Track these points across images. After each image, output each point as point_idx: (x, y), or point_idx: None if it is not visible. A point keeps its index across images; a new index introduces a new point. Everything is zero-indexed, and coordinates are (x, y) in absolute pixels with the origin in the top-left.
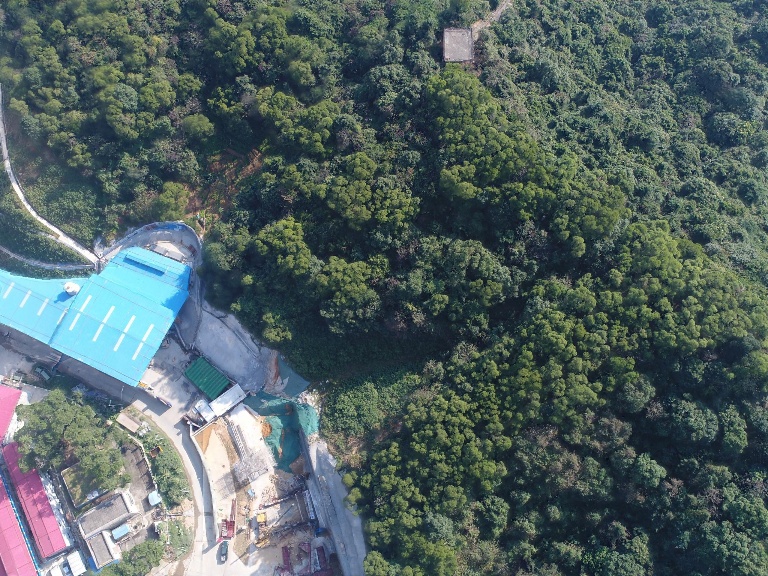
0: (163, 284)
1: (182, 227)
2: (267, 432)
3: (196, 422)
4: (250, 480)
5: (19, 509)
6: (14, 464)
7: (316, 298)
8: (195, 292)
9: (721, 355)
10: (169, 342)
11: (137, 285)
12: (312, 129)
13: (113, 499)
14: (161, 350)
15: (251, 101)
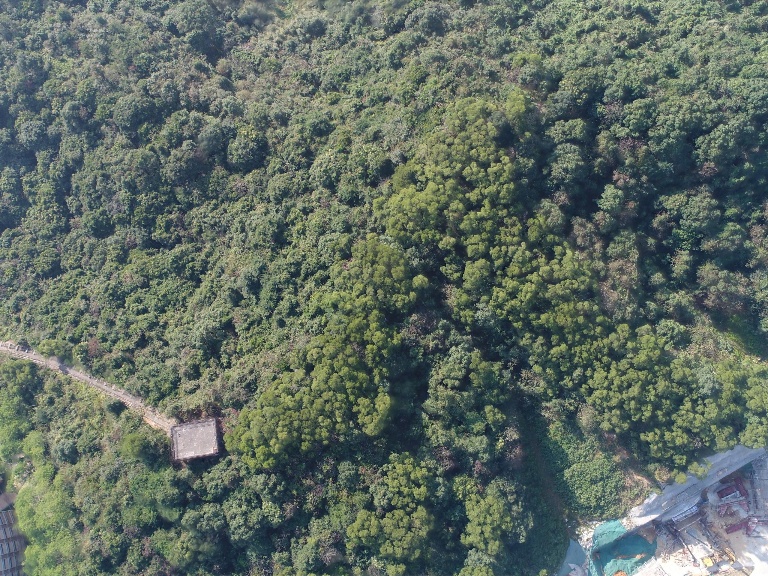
0: None
1: None
2: (622, 575)
3: None
4: None
5: None
6: None
7: None
8: None
9: (504, 144)
10: None
11: None
12: None
13: None
14: None
15: None
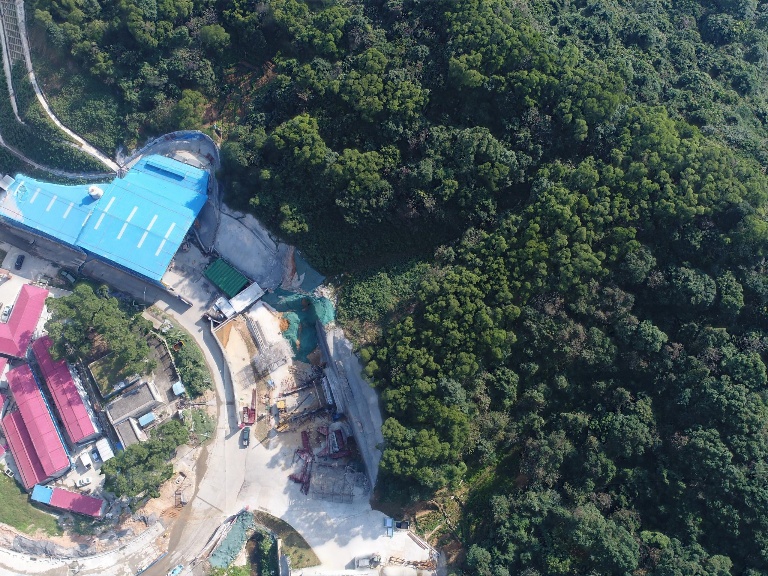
0: (183, 188)
1: (200, 136)
2: (285, 327)
3: (216, 319)
4: (269, 371)
5: (48, 401)
6: (44, 357)
7: (331, 191)
8: (213, 197)
9: (718, 225)
10: (189, 246)
11: (158, 189)
12: (325, 31)
13: (139, 388)
14: (181, 254)
15: (265, 10)
